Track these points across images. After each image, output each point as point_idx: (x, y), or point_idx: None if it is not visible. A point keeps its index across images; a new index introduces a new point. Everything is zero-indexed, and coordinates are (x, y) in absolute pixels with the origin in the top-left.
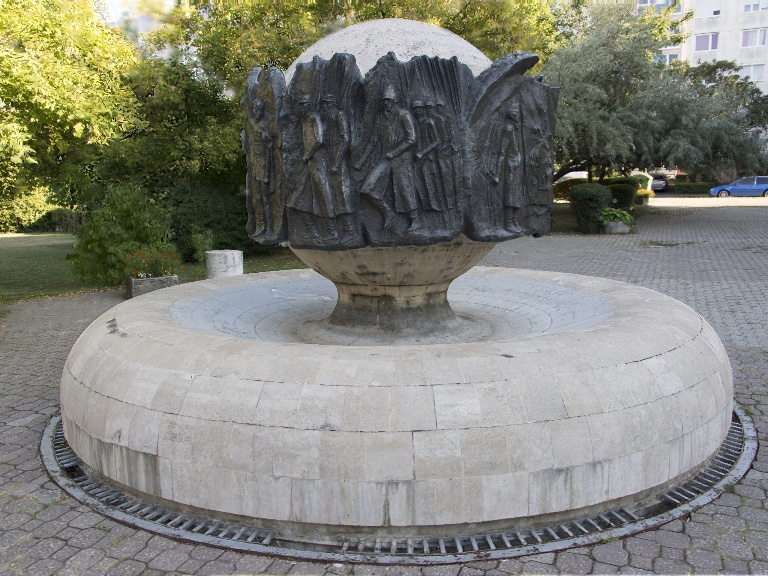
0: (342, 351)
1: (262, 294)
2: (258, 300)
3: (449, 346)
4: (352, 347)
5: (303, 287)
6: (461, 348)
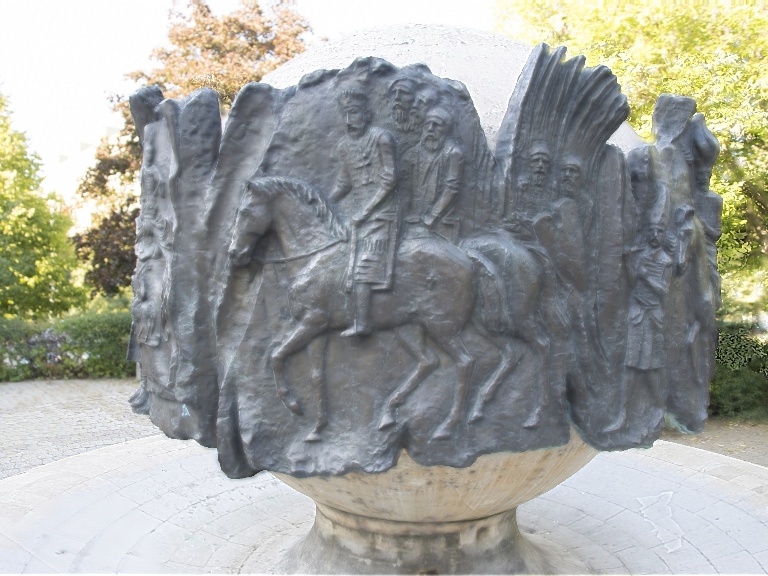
0: (155, 438)
1: (638, 486)
2: (605, 485)
3: (85, 462)
4: (158, 441)
5: (709, 516)
6: (70, 463)
